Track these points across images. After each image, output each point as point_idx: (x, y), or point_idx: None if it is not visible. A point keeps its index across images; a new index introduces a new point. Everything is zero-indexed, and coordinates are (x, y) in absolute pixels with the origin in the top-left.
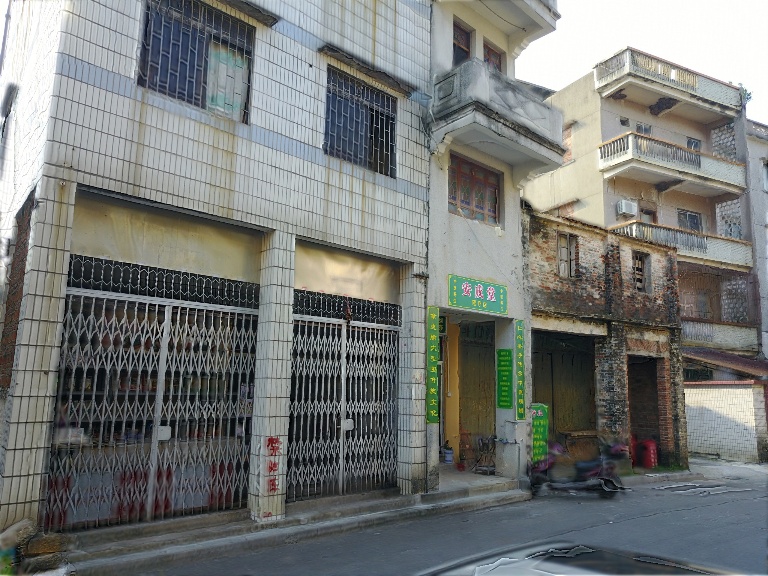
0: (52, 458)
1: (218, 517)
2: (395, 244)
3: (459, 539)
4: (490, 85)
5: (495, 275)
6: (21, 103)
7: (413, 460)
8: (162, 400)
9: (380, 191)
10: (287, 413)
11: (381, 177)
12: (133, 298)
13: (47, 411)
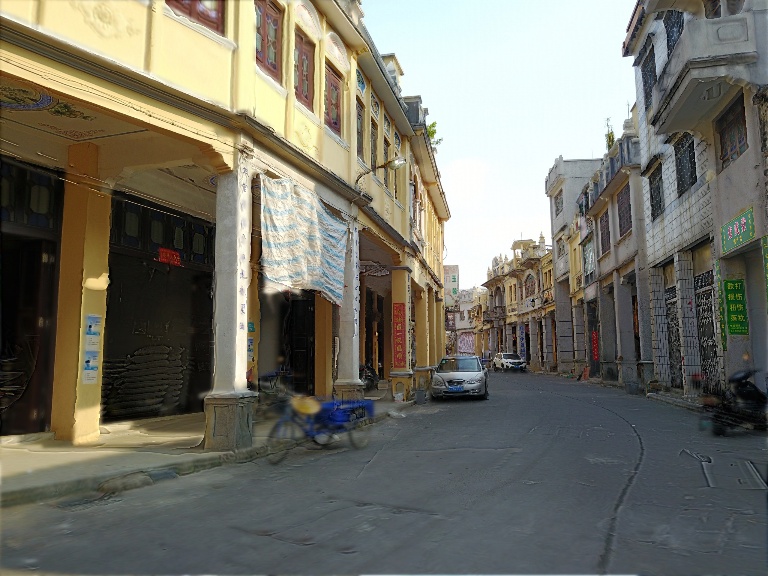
0: None
1: None
2: None
3: None
4: None
5: None
6: None
7: None
8: None
9: None
10: None
11: None
12: None
13: None
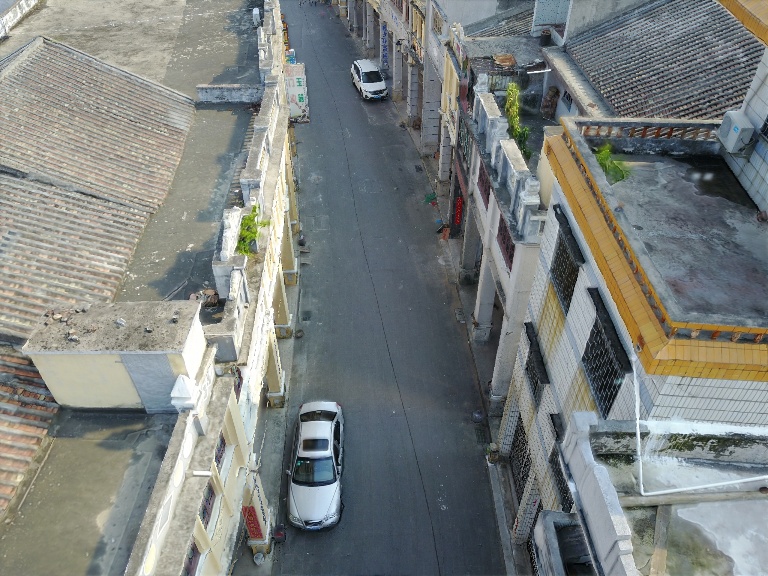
0: None
1: None
2: None
3: None
4: None
5: None
6: None
7: None
8: None
9: None
10: None
11: None
12: None
13: None
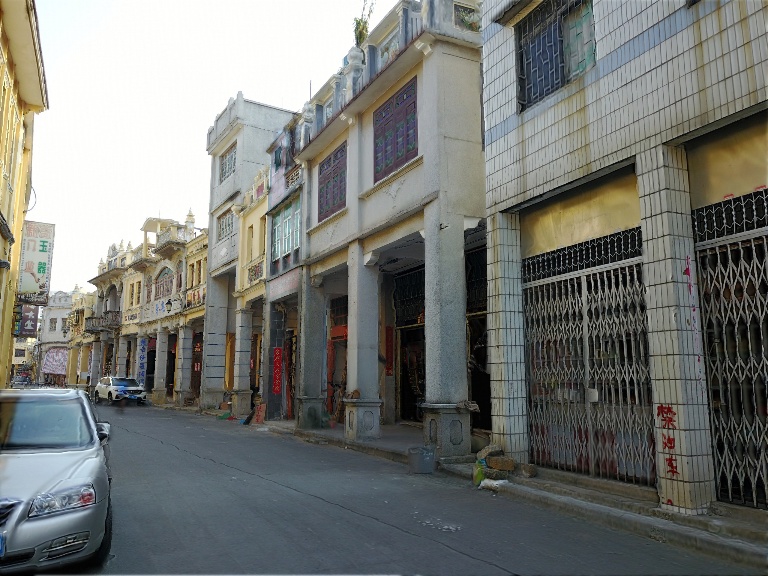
0: (532, 409)
1: (639, 491)
2: None
3: None
4: None
5: None
6: None
7: None
8: (588, 364)
9: None
10: (677, 375)
11: None
12: (558, 278)
13: (501, 373)
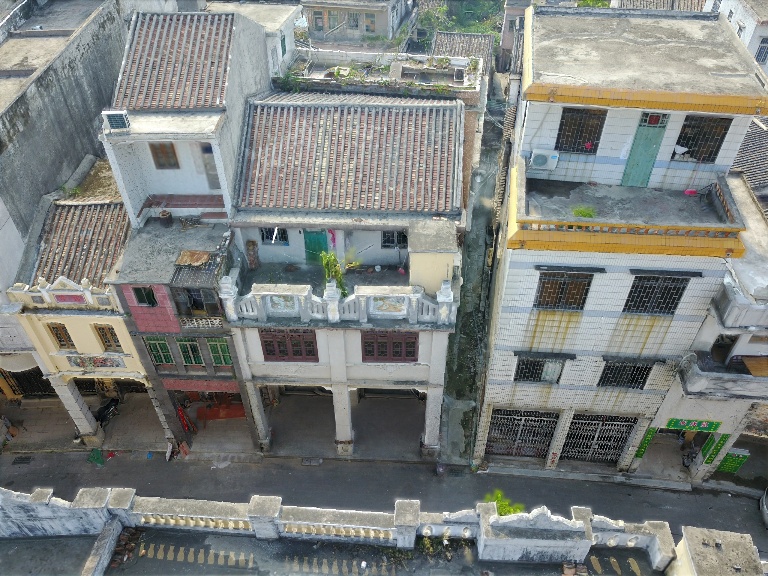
0: (488, 442)
1: (534, 460)
2: (634, 409)
3: (608, 508)
4: (710, 382)
5: (713, 418)
6: (494, 304)
7: (622, 464)
8: None
9: (630, 394)
10: (561, 449)
11: (632, 390)
12: None
13: (485, 443)
